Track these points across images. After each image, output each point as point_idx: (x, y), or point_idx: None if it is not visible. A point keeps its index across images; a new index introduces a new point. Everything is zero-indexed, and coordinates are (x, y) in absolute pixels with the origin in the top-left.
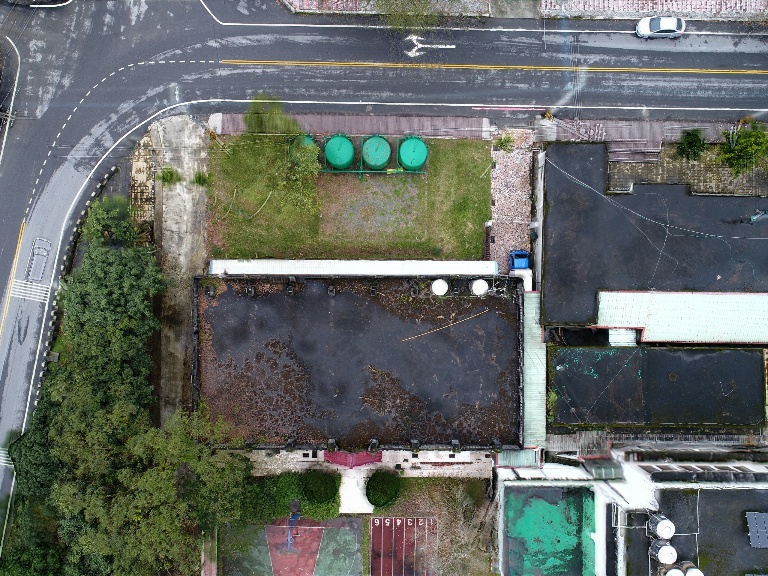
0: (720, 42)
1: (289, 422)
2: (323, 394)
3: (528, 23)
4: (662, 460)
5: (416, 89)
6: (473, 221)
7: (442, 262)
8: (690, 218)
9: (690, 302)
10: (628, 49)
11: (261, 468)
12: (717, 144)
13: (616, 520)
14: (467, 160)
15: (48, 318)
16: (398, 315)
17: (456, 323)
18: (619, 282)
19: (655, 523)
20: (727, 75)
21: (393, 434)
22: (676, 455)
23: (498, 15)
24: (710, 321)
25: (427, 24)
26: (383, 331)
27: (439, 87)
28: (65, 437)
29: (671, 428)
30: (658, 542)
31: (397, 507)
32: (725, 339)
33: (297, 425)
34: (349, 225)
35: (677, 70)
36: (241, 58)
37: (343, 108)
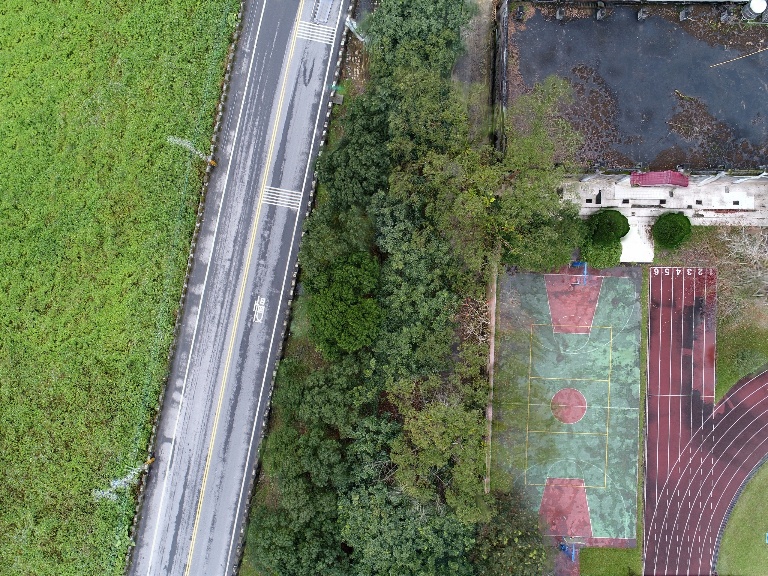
0: None
1: (595, 147)
2: (630, 120)
3: None
4: None
5: None
6: None
7: None
8: None
9: None
10: None
11: (543, 215)
12: None
13: None
14: None
15: (333, 60)
16: (706, 41)
17: (765, 49)
18: None
19: None
20: None
21: (699, 160)
22: None
23: None
24: None
25: None
26: (691, 57)
27: None
28: (412, 124)
29: None
30: None
31: (677, 256)
32: None
33: (603, 151)
34: None
35: None
36: None
37: None
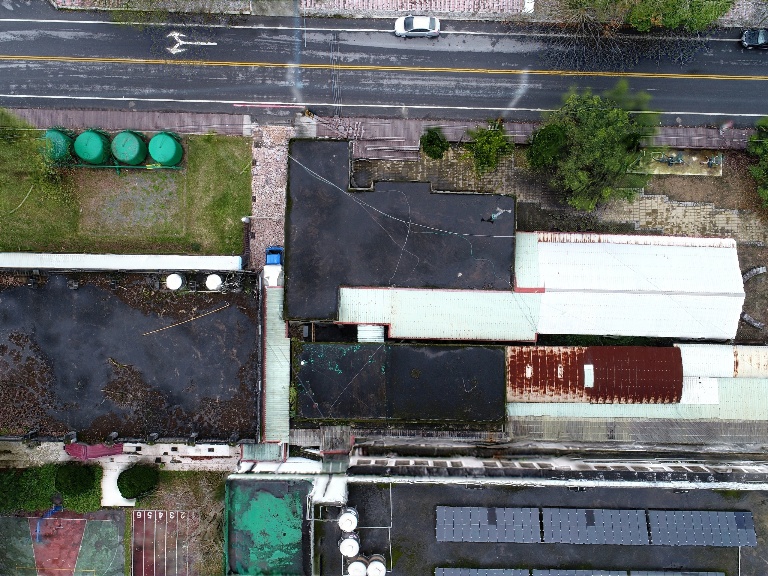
0: (478, 42)
1: (32, 414)
2: (66, 387)
3: (289, 21)
4: (385, 455)
5: (178, 85)
6: (233, 217)
7: (187, 257)
8: (432, 216)
9: (431, 299)
10: (387, 48)
11: (23, 460)
12: (476, 143)
13: (310, 513)
14: (227, 156)
15: None
16: (140, 309)
17: (197, 317)
18: (361, 278)
19: (340, 516)
20: (485, 74)
21: (134, 427)
22: (401, 450)
23: (259, 13)
24: (454, 318)
25: (189, 21)
26: (125, 325)
27: (201, 84)
28: None
29: (412, 424)
30: (343, 535)
31: (159, 500)
32: (471, 336)
33: (40, 417)
34: (108, 220)
35: (436, 69)
36: (5, 53)
37: (106, 104)
